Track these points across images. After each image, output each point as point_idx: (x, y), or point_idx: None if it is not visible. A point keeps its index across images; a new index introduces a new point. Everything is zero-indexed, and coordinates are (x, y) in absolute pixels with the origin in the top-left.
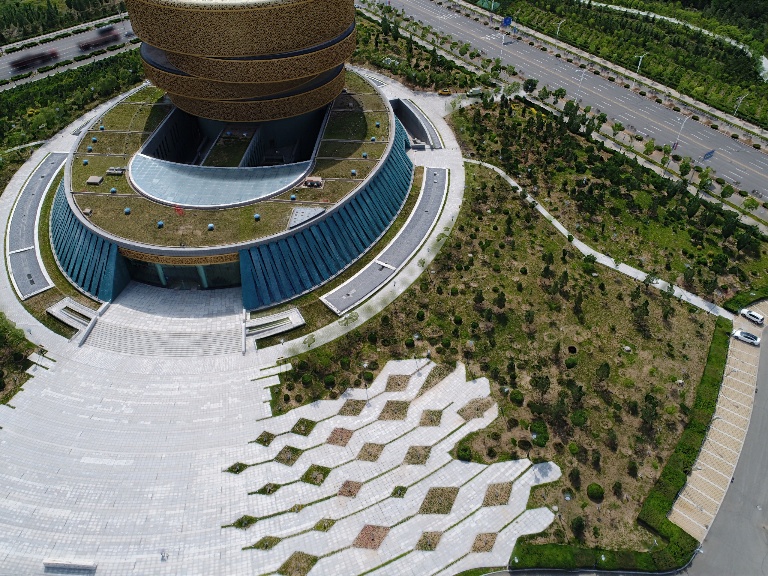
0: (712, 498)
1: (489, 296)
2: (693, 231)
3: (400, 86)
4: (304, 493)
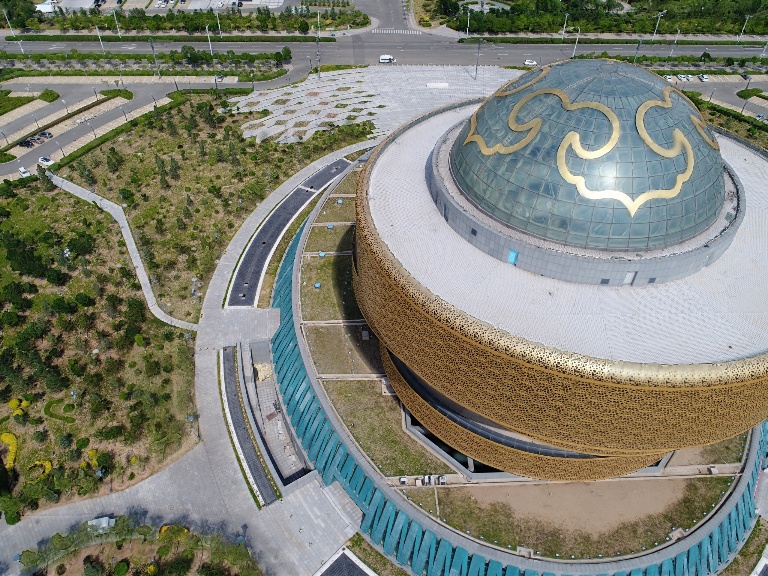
0: (147, 107)
1: (225, 172)
2: (2, 211)
3: (277, 575)
4: (346, 102)
